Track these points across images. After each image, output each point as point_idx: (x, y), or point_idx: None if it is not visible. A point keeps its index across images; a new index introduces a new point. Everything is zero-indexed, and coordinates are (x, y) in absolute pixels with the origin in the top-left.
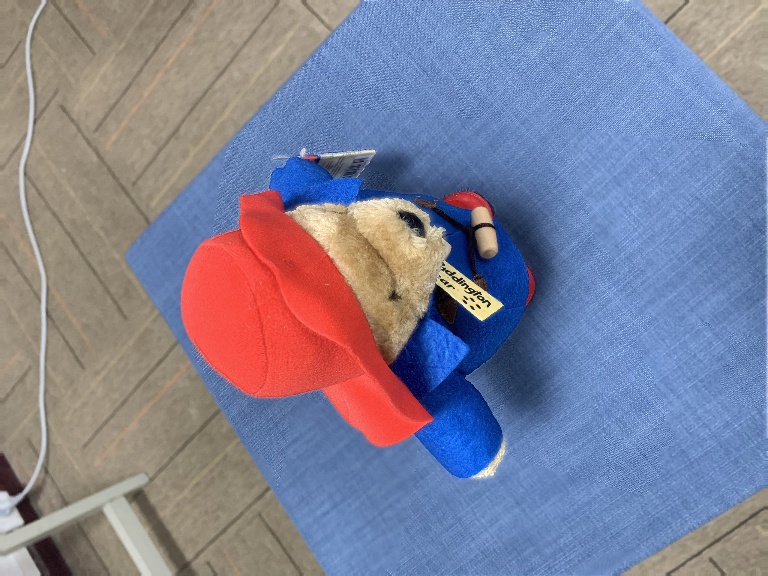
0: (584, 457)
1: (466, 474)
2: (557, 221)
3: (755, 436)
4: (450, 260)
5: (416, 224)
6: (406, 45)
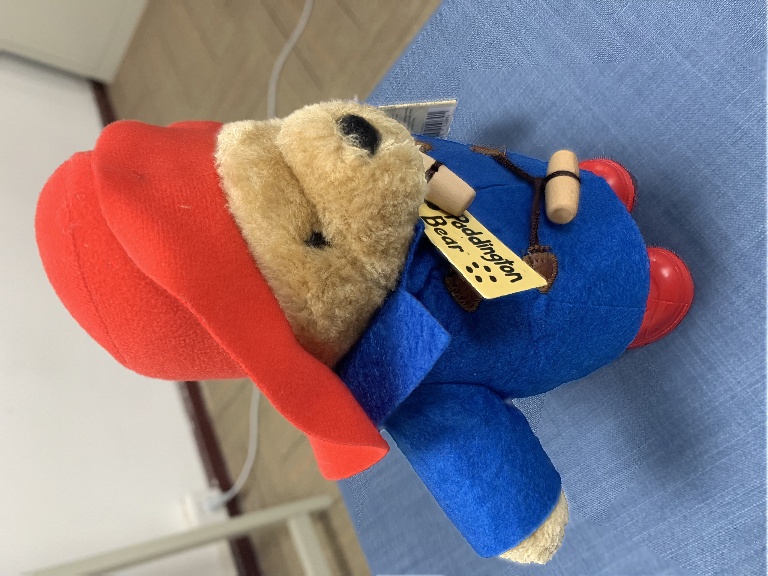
0: (765, 571)
1: (485, 552)
2: (734, 194)
3: None
4: (487, 219)
5: (356, 129)
6: None
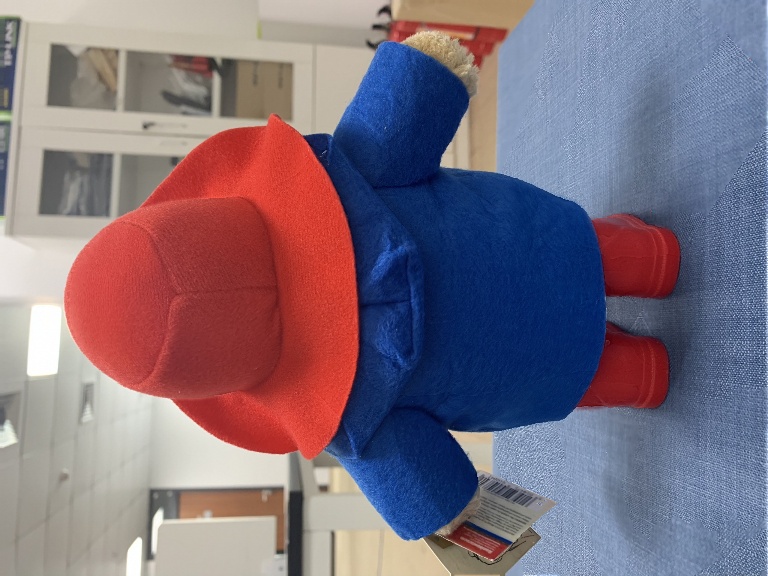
0: None
1: None
2: None
3: (561, 4)
4: None
5: None
6: (559, 571)
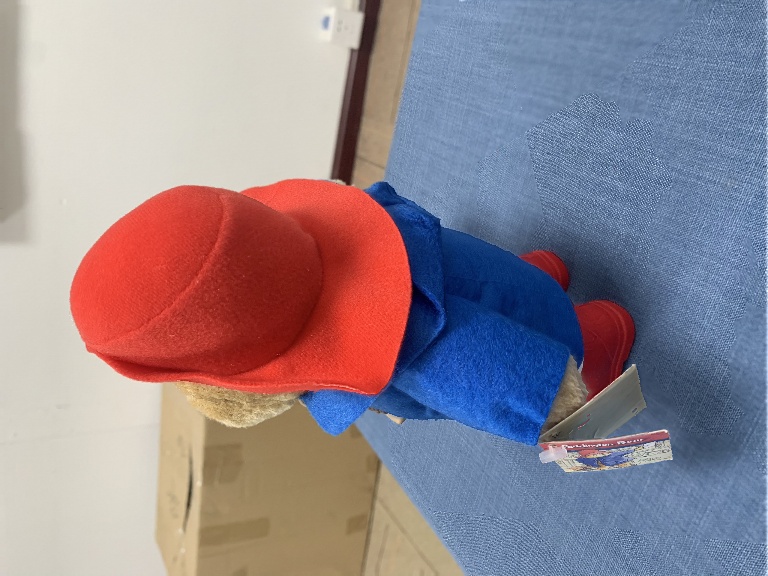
0: None
1: None
2: None
3: None
4: None
5: None
6: None
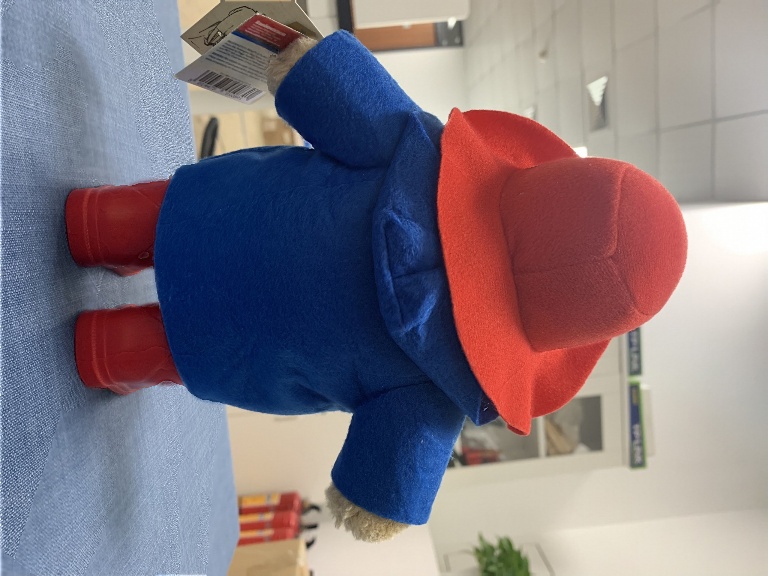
0: None
1: None
2: None
3: None
4: None
5: None
6: None
